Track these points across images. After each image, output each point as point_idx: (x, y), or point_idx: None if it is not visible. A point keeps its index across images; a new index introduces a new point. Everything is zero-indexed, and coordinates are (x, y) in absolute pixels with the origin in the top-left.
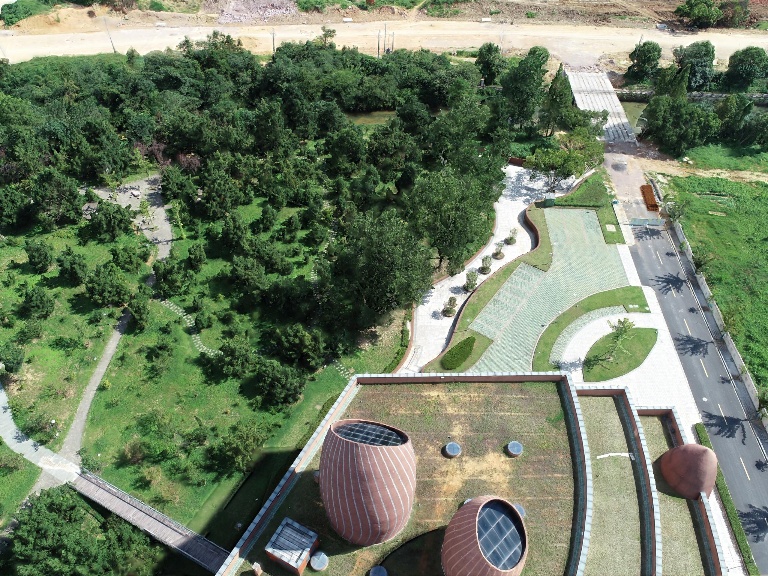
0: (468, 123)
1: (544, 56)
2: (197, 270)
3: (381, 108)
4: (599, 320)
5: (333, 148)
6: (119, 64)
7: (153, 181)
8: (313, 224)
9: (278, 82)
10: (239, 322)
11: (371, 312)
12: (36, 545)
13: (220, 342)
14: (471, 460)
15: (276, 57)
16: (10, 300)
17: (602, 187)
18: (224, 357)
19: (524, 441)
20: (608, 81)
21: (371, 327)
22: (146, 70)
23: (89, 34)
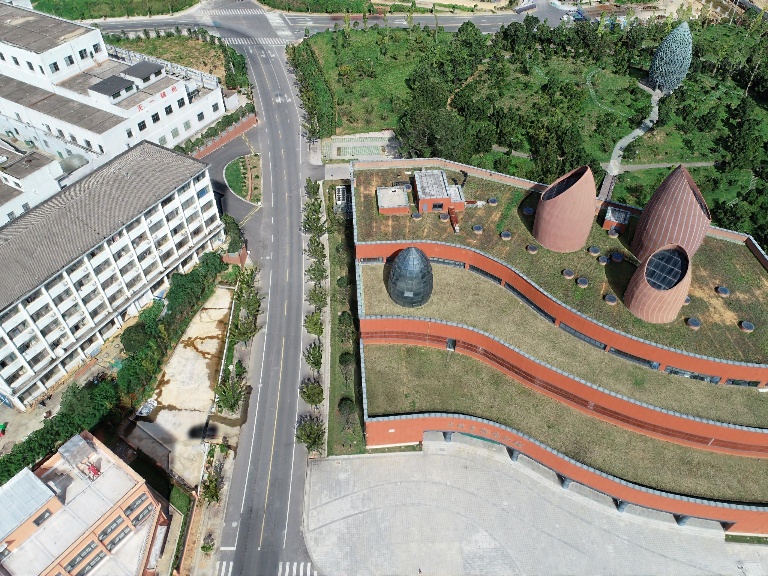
0: None
1: None
2: None
3: None
4: None
5: None
6: None
7: None
8: None
9: None
10: (767, 218)
11: None
12: None
13: None
14: (721, 302)
15: None
16: None
17: None
18: None
19: (759, 335)
20: None
21: None
22: None
23: None
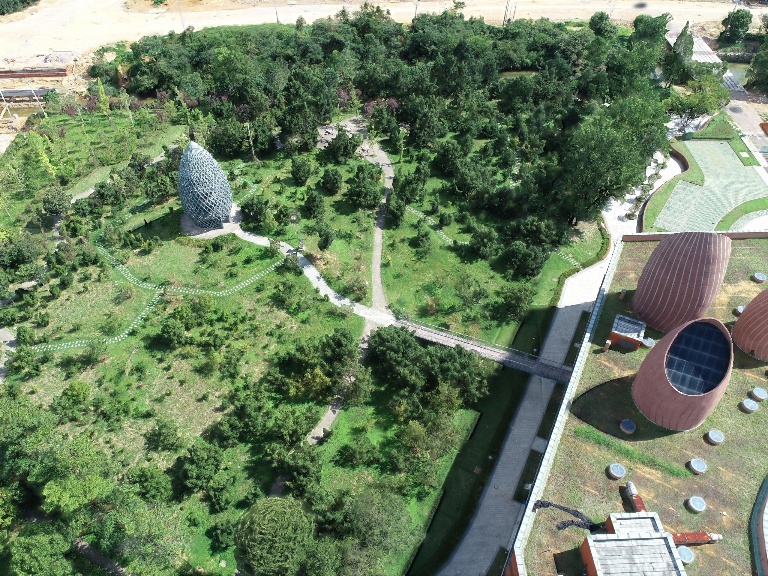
0: (639, 62)
1: (670, 16)
2: (422, 185)
3: (511, 69)
4: (757, 219)
5: (505, 92)
6: (285, 32)
7: (355, 121)
8: (502, 152)
9: (426, 45)
10: None
11: (584, 209)
12: (405, 354)
13: (461, 235)
14: (729, 285)
15: (416, 26)
16: (287, 204)
17: (728, 124)
18: (480, 240)
19: None
20: (705, 44)
21: (574, 226)
22: (315, 35)
23: (231, 11)
